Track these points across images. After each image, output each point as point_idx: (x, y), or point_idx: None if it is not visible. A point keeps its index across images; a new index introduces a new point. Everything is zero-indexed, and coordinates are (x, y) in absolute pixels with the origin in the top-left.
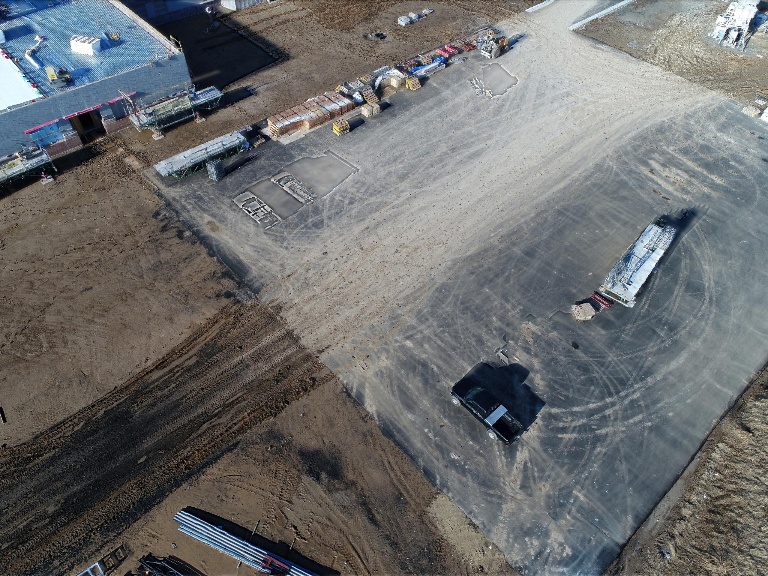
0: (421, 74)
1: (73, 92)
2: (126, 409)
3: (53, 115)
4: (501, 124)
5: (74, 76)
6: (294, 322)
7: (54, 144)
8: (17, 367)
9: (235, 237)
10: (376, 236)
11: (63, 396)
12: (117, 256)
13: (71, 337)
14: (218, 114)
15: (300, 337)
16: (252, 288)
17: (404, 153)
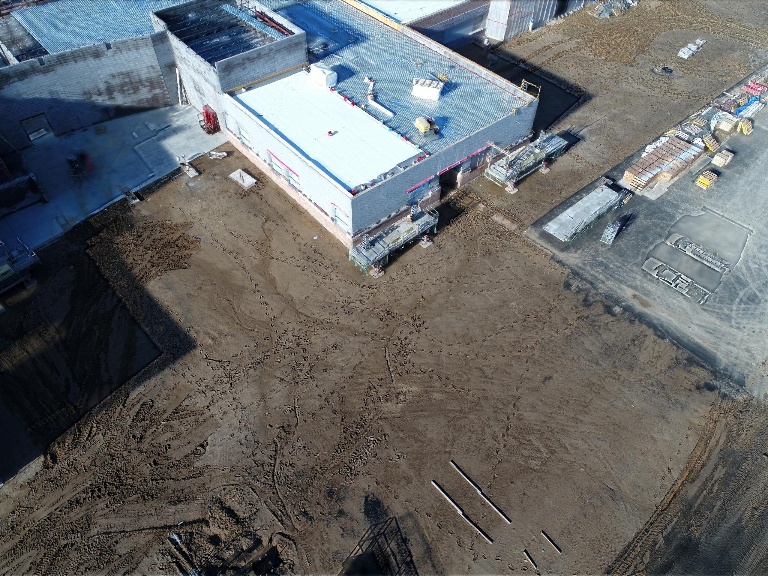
0: (747, 116)
1: (454, 146)
2: (686, 535)
3: (431, 171)
4: None
5: (439, 126)
6: None
7: (421, 201)
8: (529, 478)
9: (674, 314)
10: None
11: (605, 517)
12: (555, 337)
13: (566, 440)
14: (559, 163)
15: None
16: (734, 379)
17: None
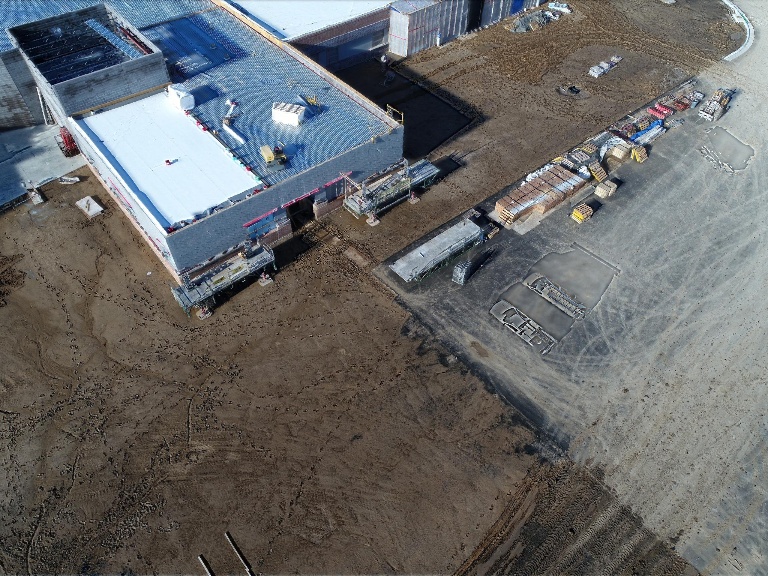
0: (644, 142)
1: (296, 178)
2: None
3: (273, 204)
4: (760, 209)
5: (288, 155)
6: (626, 494)
7: (267, 235)
8: (307, 554)
9: (511, 365)
10: (677, 366)
11: None
12: (377, 389)
13: (359, 509)
14: (431, 192)
15: (642, 517)
16: (557, 442)
17: (664, 248)
